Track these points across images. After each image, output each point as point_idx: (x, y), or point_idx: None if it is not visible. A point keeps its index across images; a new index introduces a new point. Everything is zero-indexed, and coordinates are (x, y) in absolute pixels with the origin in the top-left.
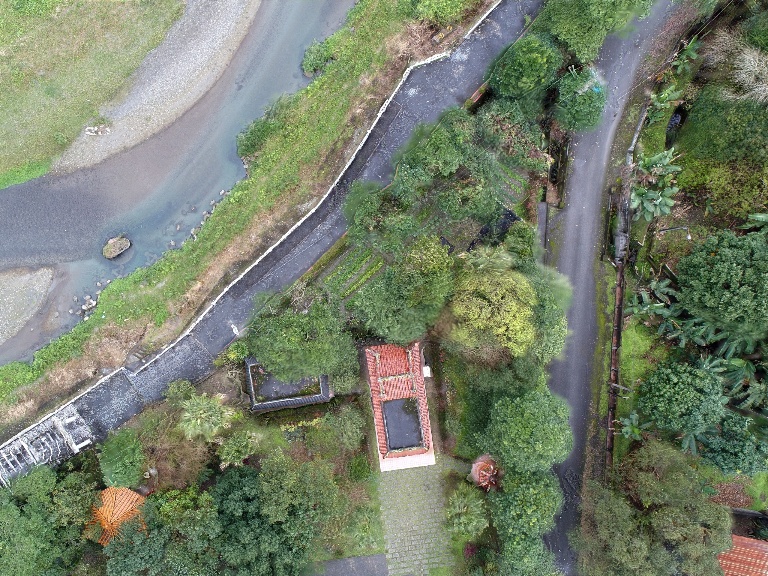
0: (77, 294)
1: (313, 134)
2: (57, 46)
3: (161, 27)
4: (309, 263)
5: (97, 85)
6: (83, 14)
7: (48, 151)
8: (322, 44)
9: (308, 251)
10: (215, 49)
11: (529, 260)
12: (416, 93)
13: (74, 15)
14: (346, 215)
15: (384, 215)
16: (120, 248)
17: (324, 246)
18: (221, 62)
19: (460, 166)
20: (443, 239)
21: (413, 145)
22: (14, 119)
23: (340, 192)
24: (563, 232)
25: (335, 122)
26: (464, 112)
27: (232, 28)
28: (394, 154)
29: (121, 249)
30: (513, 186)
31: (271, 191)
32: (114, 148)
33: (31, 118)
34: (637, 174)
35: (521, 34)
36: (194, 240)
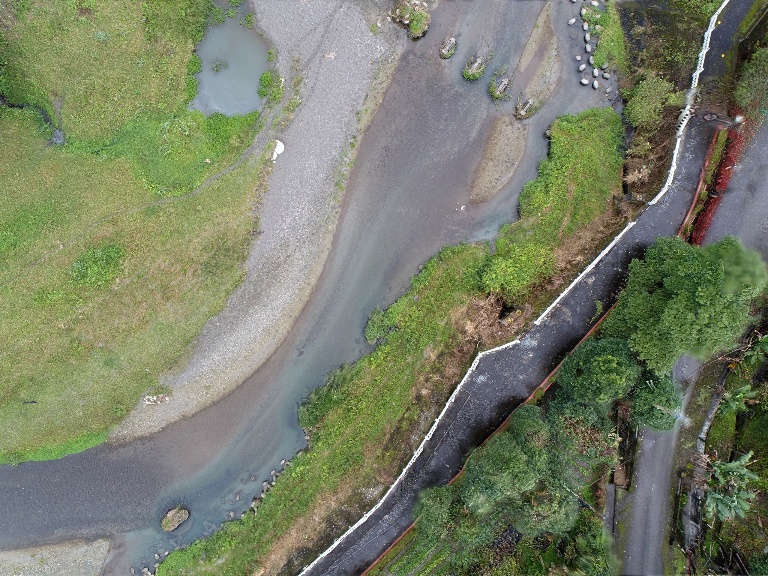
0: (134, 565)
1: (377, 410)
2: (117, 318)
3: (222, 295)
4: (375, 554)
5: (156, 354)
6: (143, 285)
7: (106, 421)
8: (386, 313)
9: (374, 542)
10: (276, 316)
11: (603, 569)
12: (485, 380)
13: (134, 286)
14: (413, 505)
15: (455, 522)
16: (179, 522)
17: (390, 537)
18: (282, 329)
19: (536, 483)
20: (511, 527)
21: (482, 434)
22: (72, 390)
23: (407, 482)
24: (631, 514)
25: (399, 398)
26: (537, 413)
27: (294, 295)
28: (462, 443)
29: (180, 522)
30: (581, 469)
31: (334, 470)
32: (173, 417)
33: (89, 389)
34: (713, 479)
35: (593, 325)
36: (254, 514)
